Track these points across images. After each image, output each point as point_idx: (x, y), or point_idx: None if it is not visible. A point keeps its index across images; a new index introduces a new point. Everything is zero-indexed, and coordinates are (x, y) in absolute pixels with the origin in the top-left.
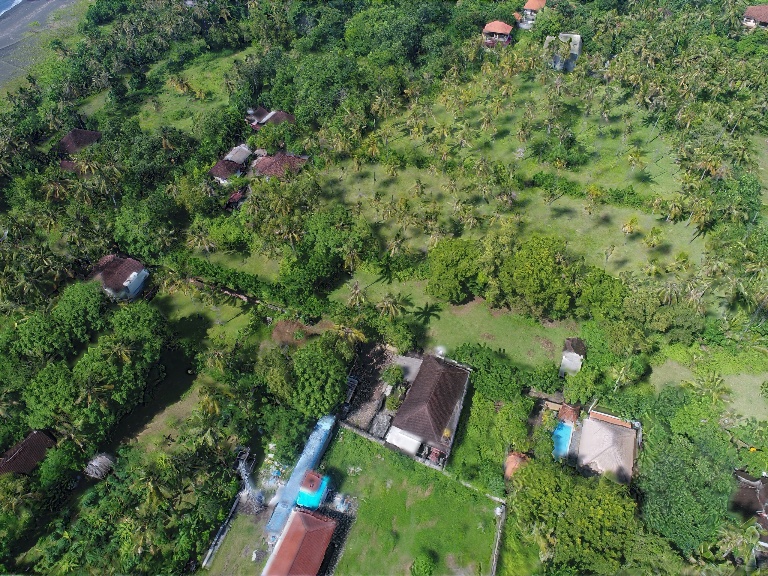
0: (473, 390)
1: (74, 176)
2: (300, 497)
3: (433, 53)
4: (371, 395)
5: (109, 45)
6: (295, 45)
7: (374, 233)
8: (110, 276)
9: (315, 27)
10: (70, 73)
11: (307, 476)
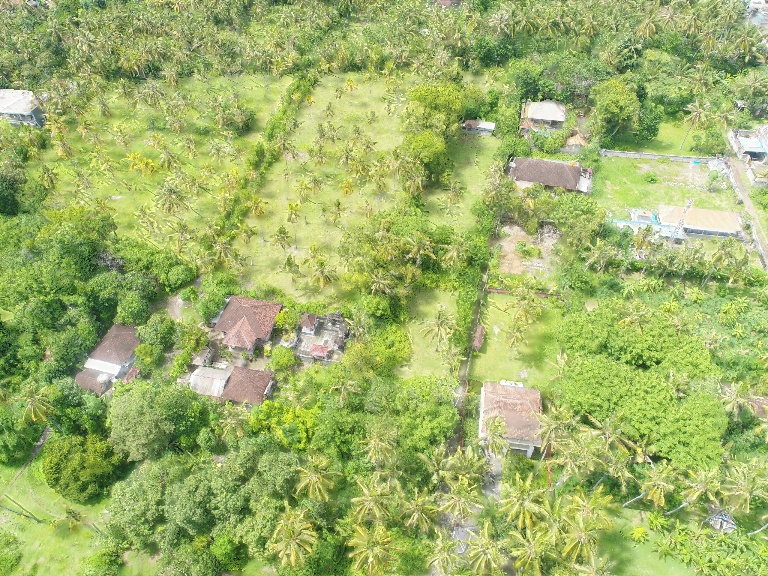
0: None
1: None
2: (653, 219)
3: None
4: None
5: None
6: None
7: None
8: None
9: None
10: None
11: (641, 214)
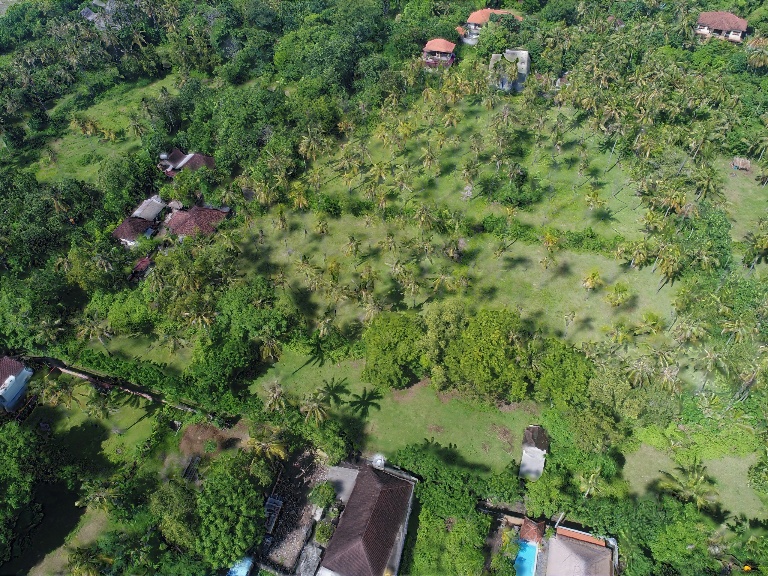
0: (419, 505)
1: None
2: None
3: (369, 78)
4: (299, 518)
5: (4, 81)
6: (218, 72)
7: (304, 300)
8: None
9: (240, 51)
10: None
11: None
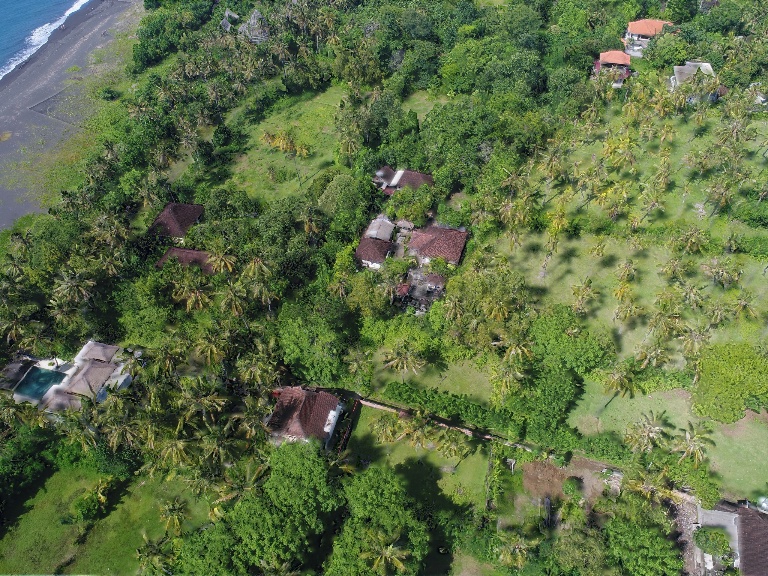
0: None
1: (199, 272)
2: None
3: (561, 92)
4: None
5: (181, 95)
6: (390, 85)
7: None
8: (306, 421)
9: (407, 63)
10: (144, 132)
11: None
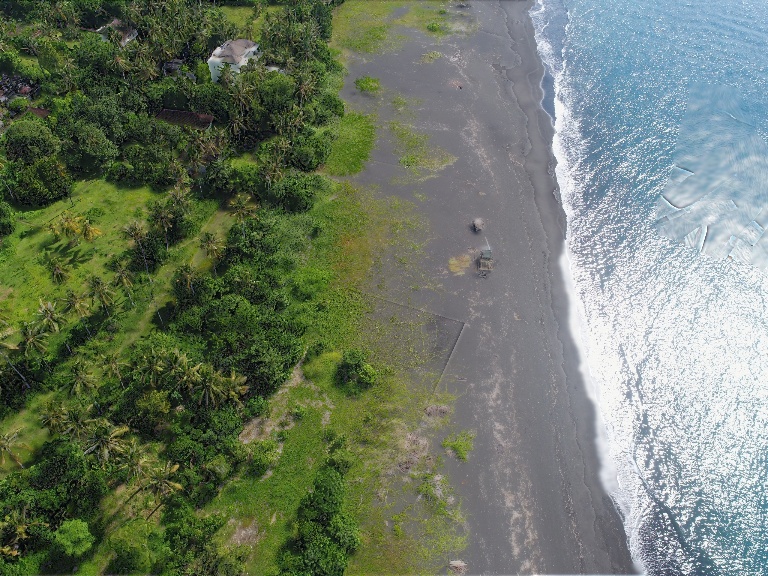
0: None
1: None
2: None
3: None
4: None
5: (197, 273)
6: None
7: None
8: None
9: None
10: None
11: None
